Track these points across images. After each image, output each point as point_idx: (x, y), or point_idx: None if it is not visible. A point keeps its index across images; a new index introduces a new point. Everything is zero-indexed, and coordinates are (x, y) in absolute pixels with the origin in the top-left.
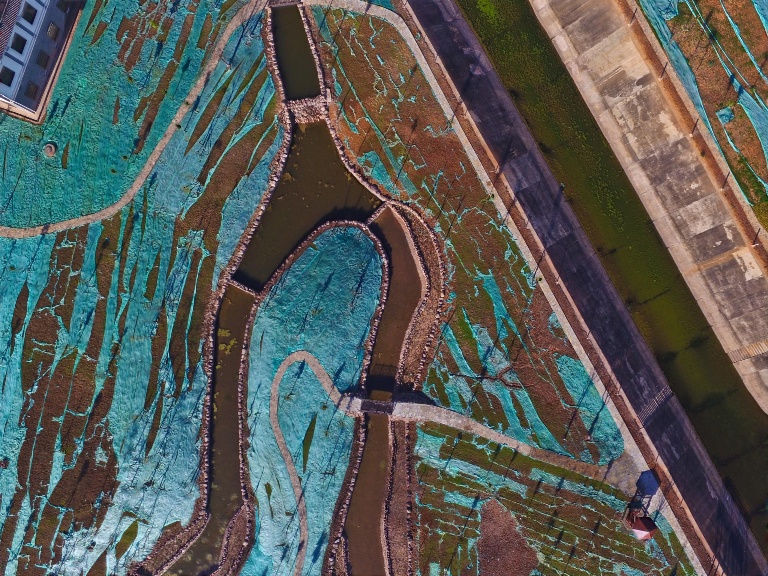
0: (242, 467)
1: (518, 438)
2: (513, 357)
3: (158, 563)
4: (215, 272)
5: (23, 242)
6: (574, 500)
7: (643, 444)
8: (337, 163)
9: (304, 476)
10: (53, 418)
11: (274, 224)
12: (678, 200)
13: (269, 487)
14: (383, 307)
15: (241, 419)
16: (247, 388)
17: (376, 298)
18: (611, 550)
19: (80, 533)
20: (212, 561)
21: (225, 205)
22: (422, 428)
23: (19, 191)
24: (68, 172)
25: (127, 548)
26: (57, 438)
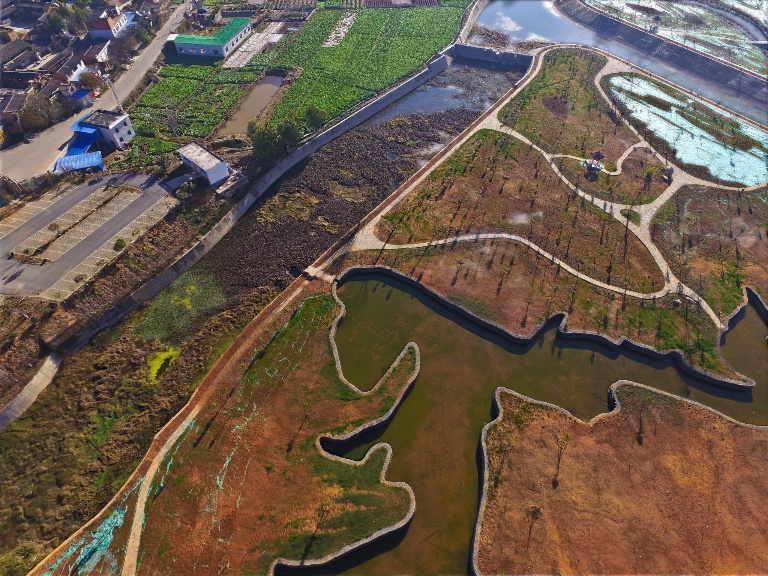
0: None
1: None
2: None
3: None
4: None
5: None
6: None
7: None
8: None
9: None
10: None
11: None
12: None
13: None
14: None
15: None
16: None
17: None
18: None
19: None
20: None
21: None
22: None
23: None
24: None
25: None
26: None
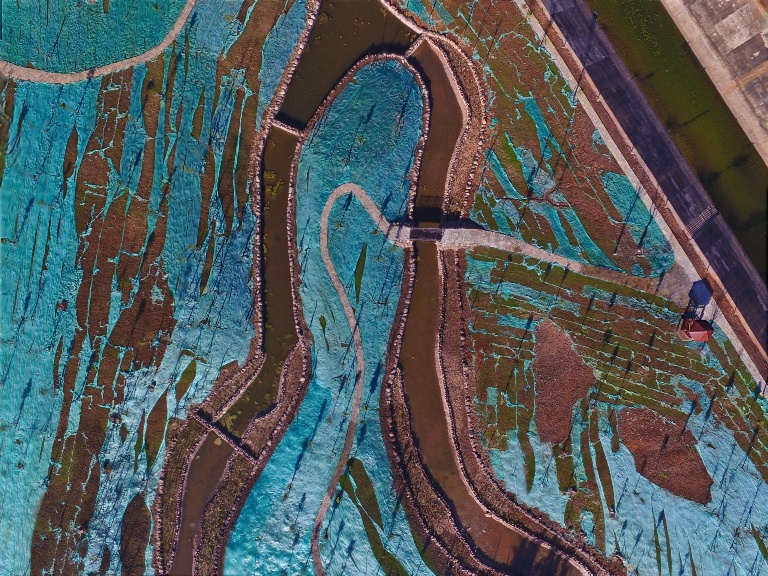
0: (295, 304)
1: (568, 256)
2: (558, 177)
3: (217, 405)
4: (258, 112)
5: (70, 87)
6: (627, 315)
7: (693, 255)
8: (372, 0)
9: (357, 306)
10: (108, 259)
11: (313, 65)
12: (713, 16)
13: (323, 320)
14: (426, 138)
15: (291, 257)
16: (296, 226)
17: (419, 128)
18: (667, 362)
19: (141, 372)
20: (270, 400)
21: (265, 44)
22: (471, 254)
23: (63, 37)
24: (110, 16)
25: (186, 389)
26: (113, 278)
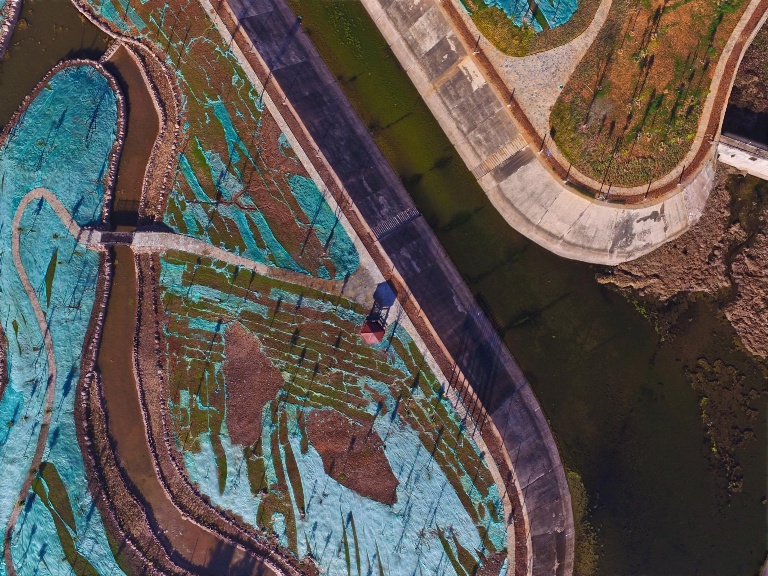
0: None
1: (255, 259)
2: (246, 180)
3: None
4: None
5: None
6: (314, 317)
7: (378, 256)
8: (71, 6)
9: (48, 310)
10: None
11: (14, 71)
12: (406, 19)
13: (16, 324)
14: (120, 142)
15: None
16: None
17: (112, 133)
18: (354, 364)
19: None
20: None
21: None
22: (164, 258)
23: None
24: None
25: None
26: None
